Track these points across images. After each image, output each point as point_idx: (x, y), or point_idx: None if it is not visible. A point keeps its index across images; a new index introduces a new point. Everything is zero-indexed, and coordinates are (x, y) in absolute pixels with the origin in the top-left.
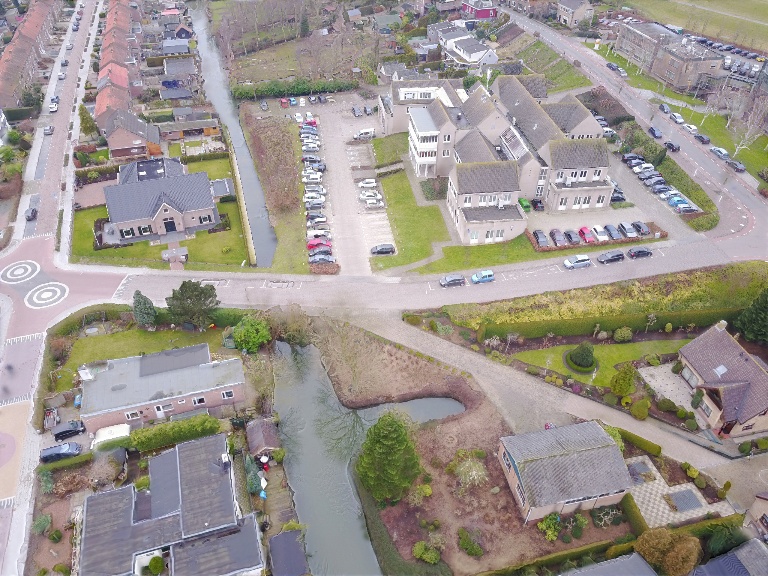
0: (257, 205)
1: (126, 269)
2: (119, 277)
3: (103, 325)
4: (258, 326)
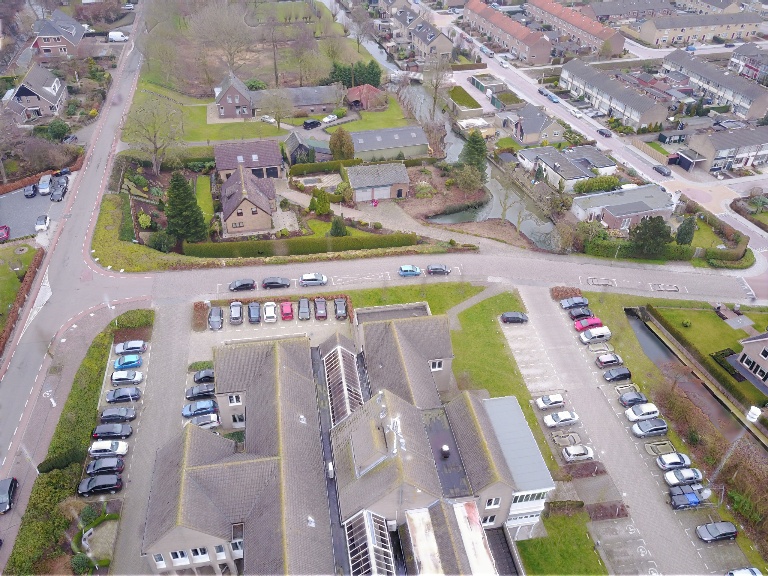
0: (721, 418)
1: (765, 303)
2: (762, 295)
3: (713, 242)
4: (588, 225)
